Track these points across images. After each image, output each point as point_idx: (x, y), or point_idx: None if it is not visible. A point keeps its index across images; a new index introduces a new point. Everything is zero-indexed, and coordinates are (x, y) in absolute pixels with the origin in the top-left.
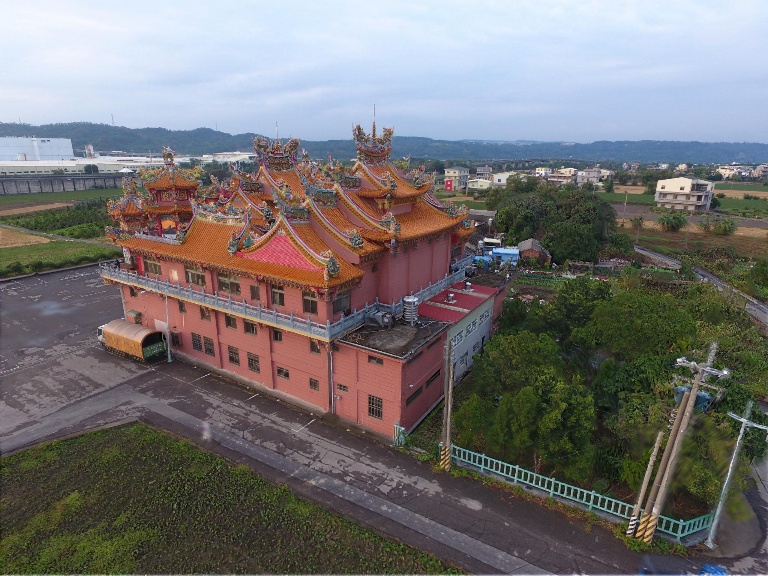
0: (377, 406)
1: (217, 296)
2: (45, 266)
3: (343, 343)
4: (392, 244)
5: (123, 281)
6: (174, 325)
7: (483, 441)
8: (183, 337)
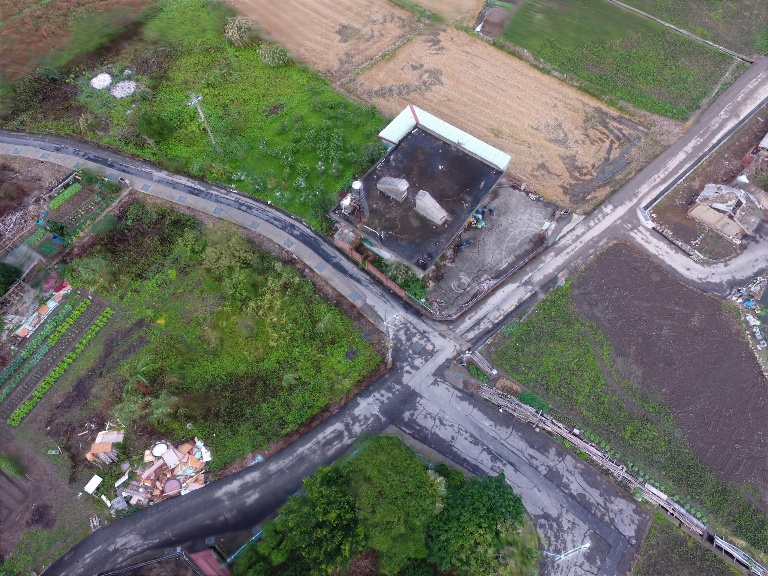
0: None
1: None
2: None
3: None
4: None
5: None
6: None
7: None
8: None
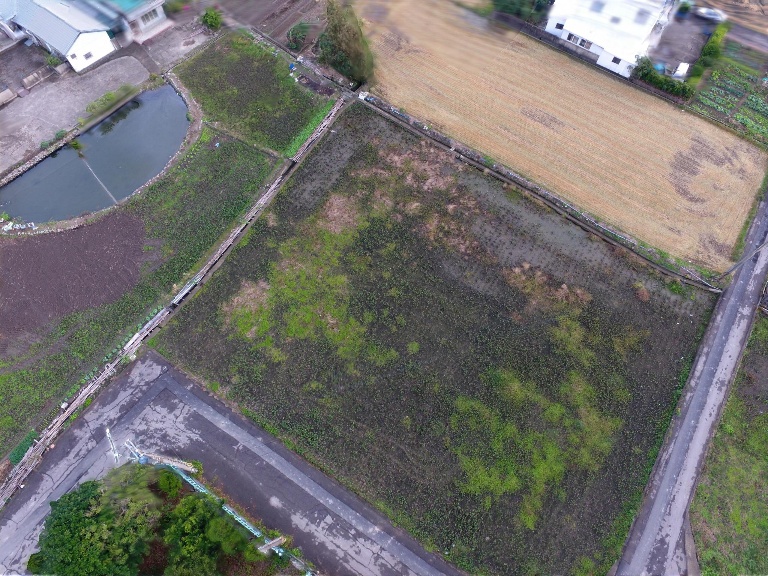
0: None
1: None
2: None
3: None
4: None
5: None
6: None
7: (243, 573)
8: None
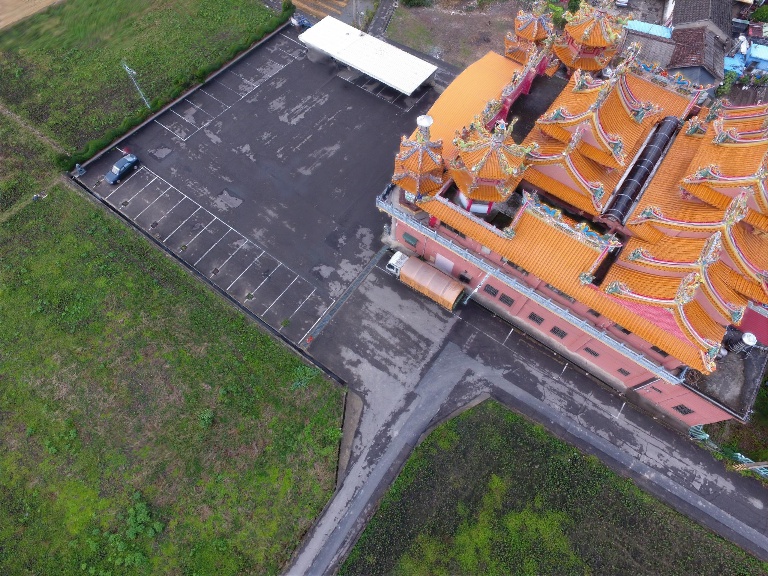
0: (686, 410)
1: (550, 301)
2: (208, 72)
3: (686, 388)
4: (766, 307)
5: (412, 227)
6: (465, 269)
7: (760, 439)
8: (474, 281)
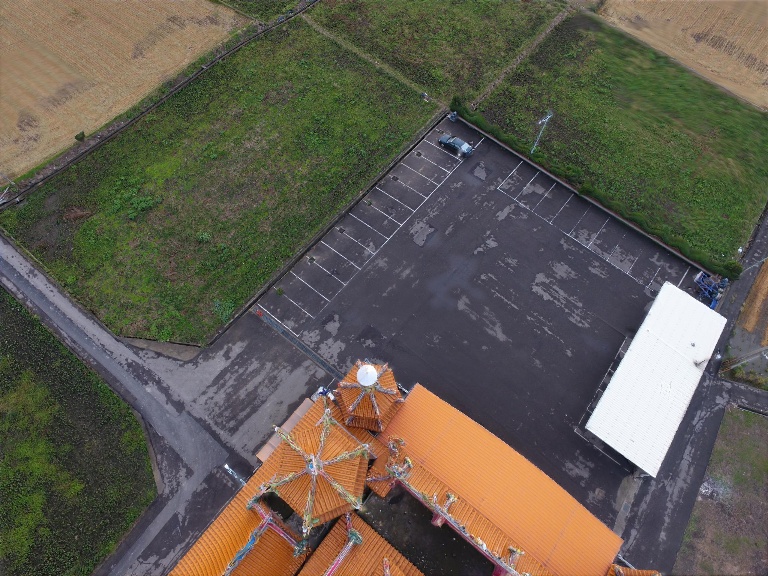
0: None
1: None
2: (594, 196)
3: None
4: None
5: None
6: None
7: None
8: None
